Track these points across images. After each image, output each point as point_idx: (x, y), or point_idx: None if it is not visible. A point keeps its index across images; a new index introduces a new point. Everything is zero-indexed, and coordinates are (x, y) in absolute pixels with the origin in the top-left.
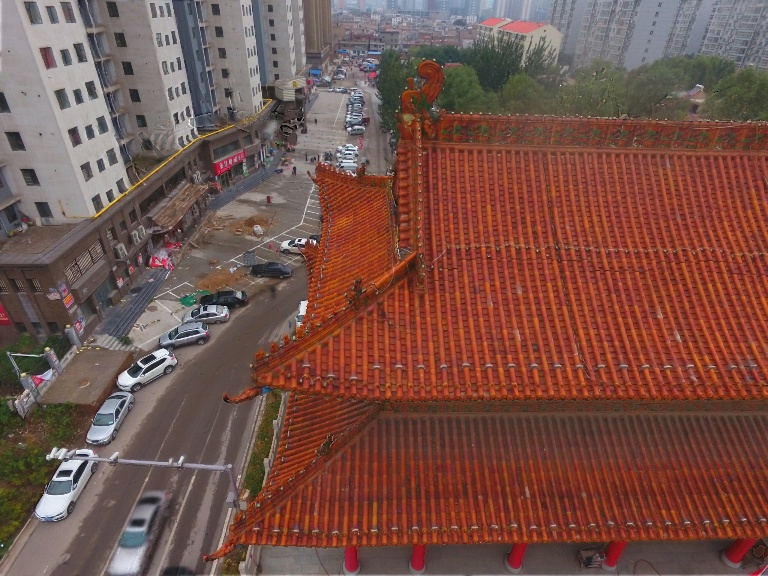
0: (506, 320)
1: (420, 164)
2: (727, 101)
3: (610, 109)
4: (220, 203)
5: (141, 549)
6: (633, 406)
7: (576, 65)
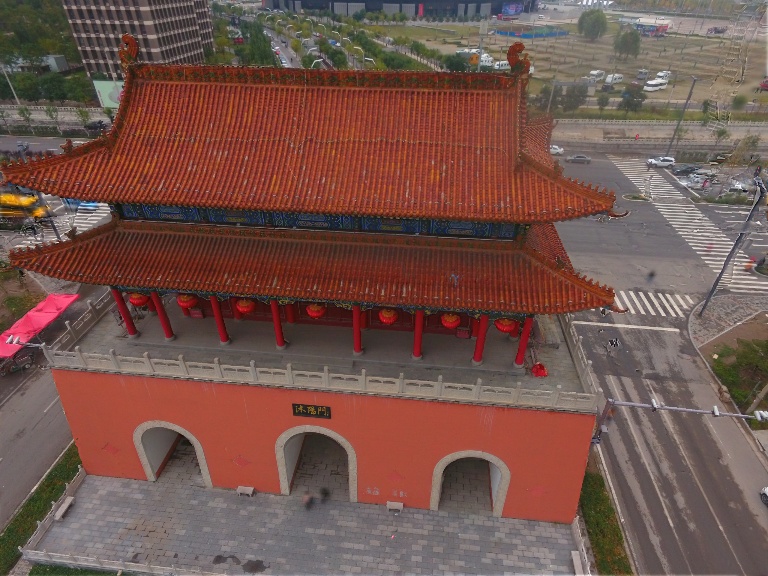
0: None
1: None
2: None
3: None
4: None
5: (666, 461)
6: None
7: None
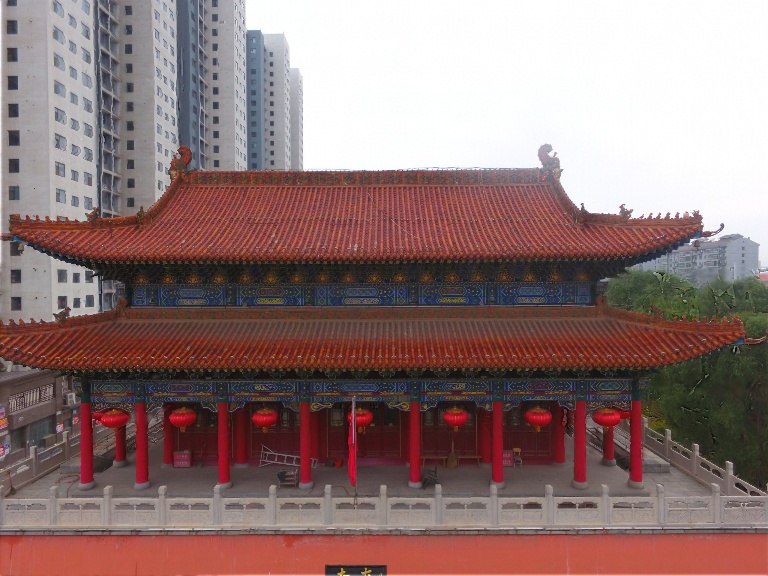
0: None
1: None
2: (613, 291)
3: None
4: None
5: None
6: (286, 314)
7: None
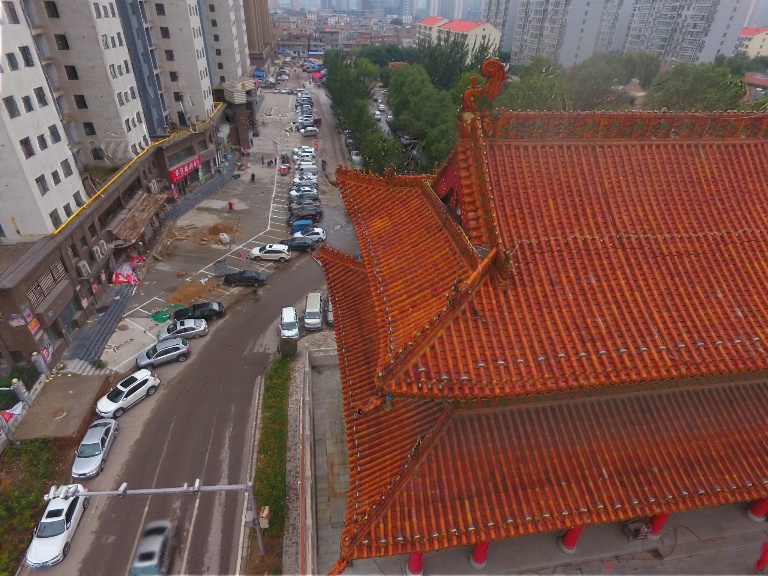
0: (586, 309)
1: (486, 162)
2: (665, 94)
3: (558, 104)
4: (179, 212)
5: None
6: (684, 382)
7: (524, 63)
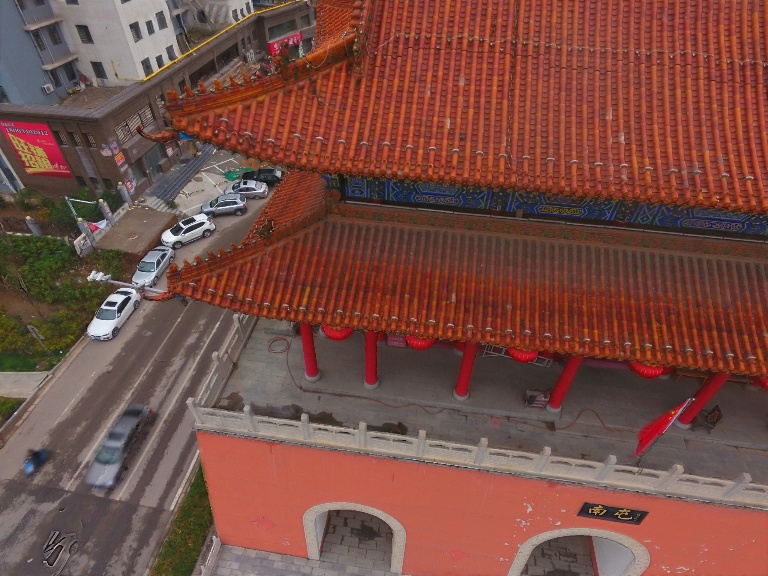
0: (440, 109)
1: None
2: None
3: None
4: None
5: (169, 371)
6: (584, 235)
7: None
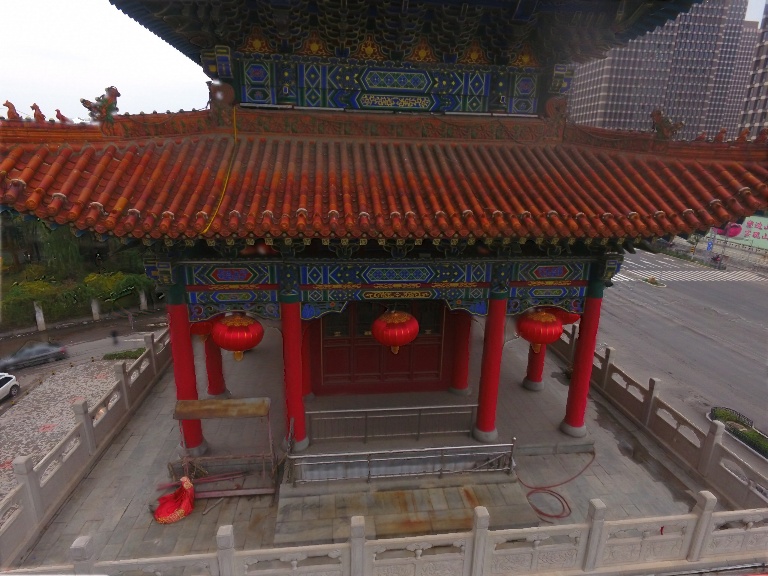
0: None
1: None
2: None
3: None
4: None
5: None
6: None
7: None
